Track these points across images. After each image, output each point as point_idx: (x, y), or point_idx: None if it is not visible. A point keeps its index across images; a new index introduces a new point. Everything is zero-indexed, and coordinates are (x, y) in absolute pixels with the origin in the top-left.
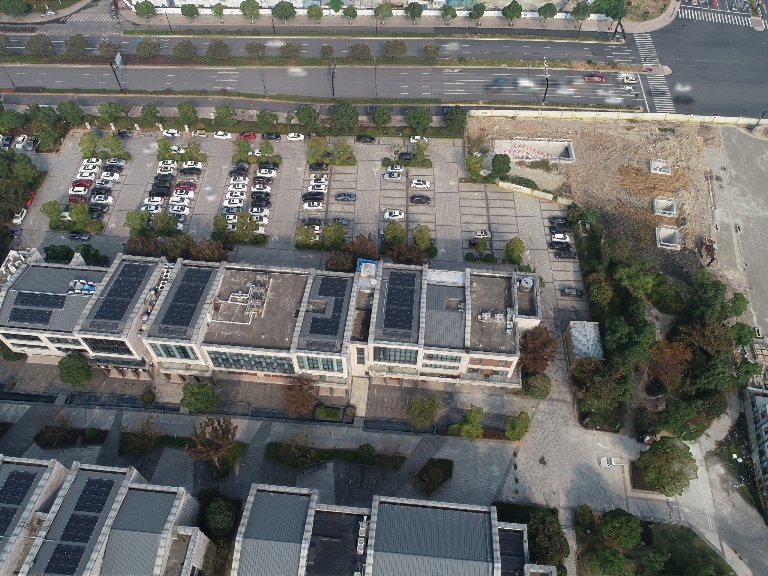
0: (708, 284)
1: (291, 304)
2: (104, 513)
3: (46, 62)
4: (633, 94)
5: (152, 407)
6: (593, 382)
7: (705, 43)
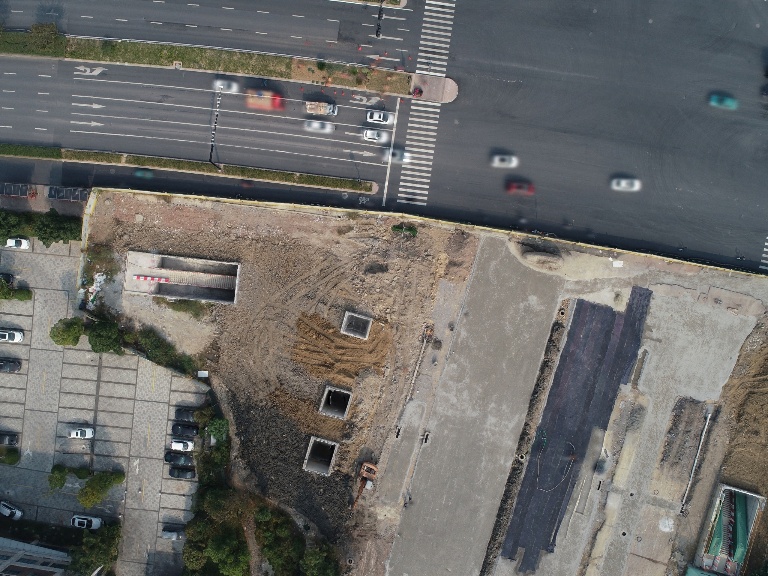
0: None
1: None
2: None
3: None
4: (373, 151)
5: None
6: None
7: (546, 15)
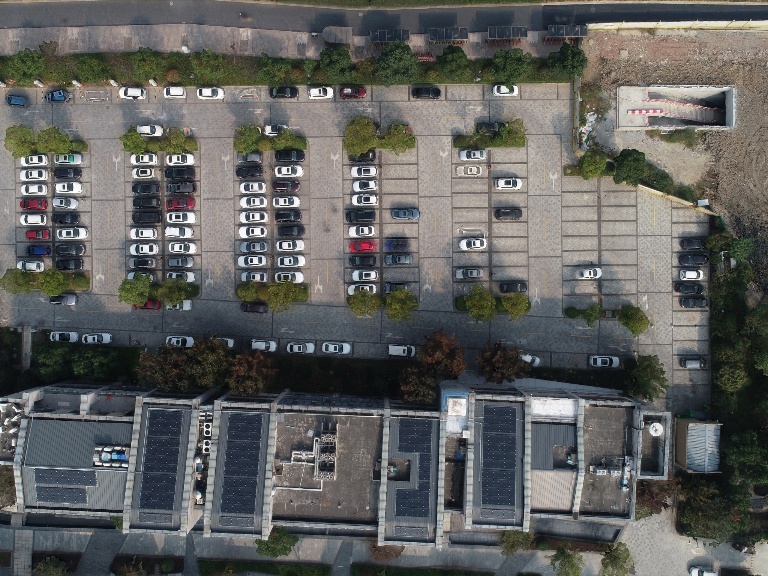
0: None
1: (366, 460)
2: None
3: None
4: None
5: None
6: (705, 514)
7: None
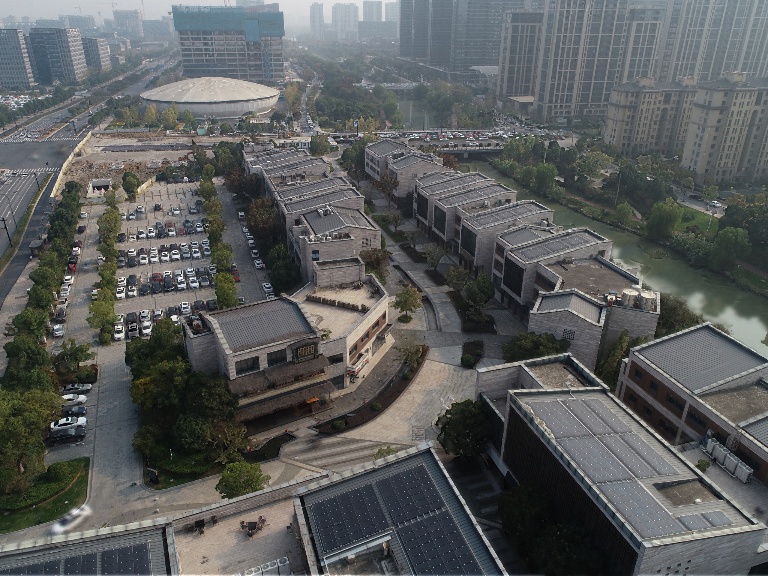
0: (222, 144)
1: None
2: None
3: None
4: None
5: None
6: None
7: None
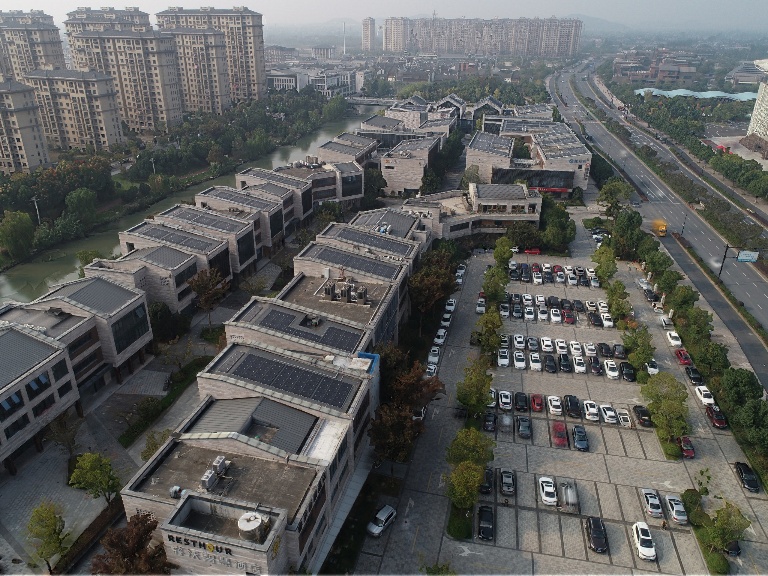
0: None
1: None
2: None
3: (736, 246)
4: None
5: None
6: None
7: None
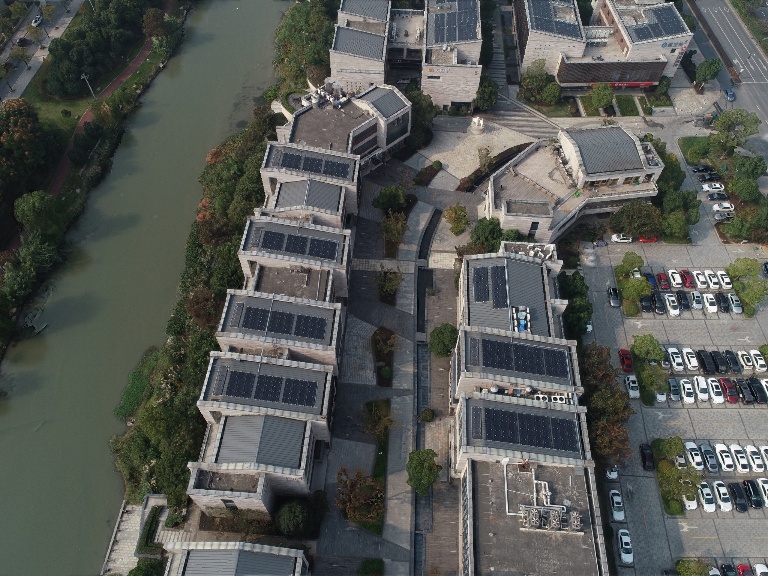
0: None
1: (548, 568)
2: (282, 405)
3: None
4: None
5: (419, 422)
6: None
7: None
